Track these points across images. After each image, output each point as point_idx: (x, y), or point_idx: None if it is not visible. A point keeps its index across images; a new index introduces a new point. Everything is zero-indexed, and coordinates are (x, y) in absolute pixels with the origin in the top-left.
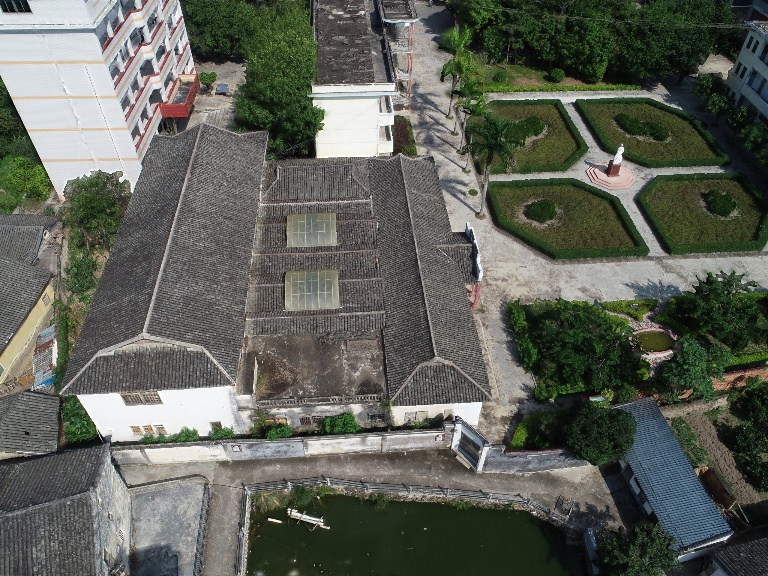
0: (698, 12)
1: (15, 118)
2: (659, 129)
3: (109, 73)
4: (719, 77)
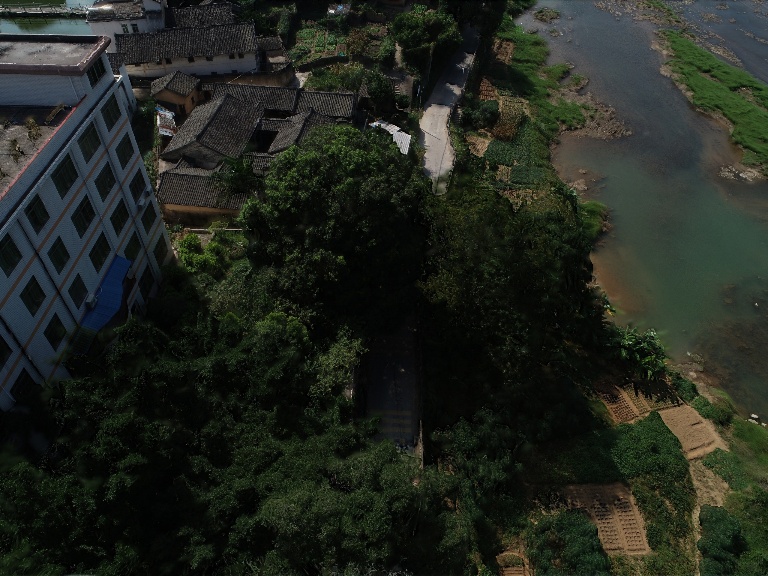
0: None
1: (214, 308)
2: None
3: None
4: None
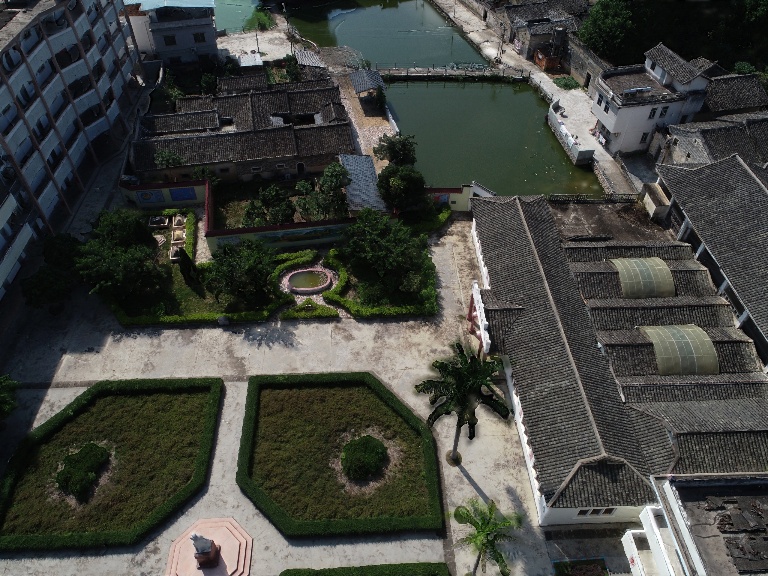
0: None
1: None
2: None
3: None
4: None
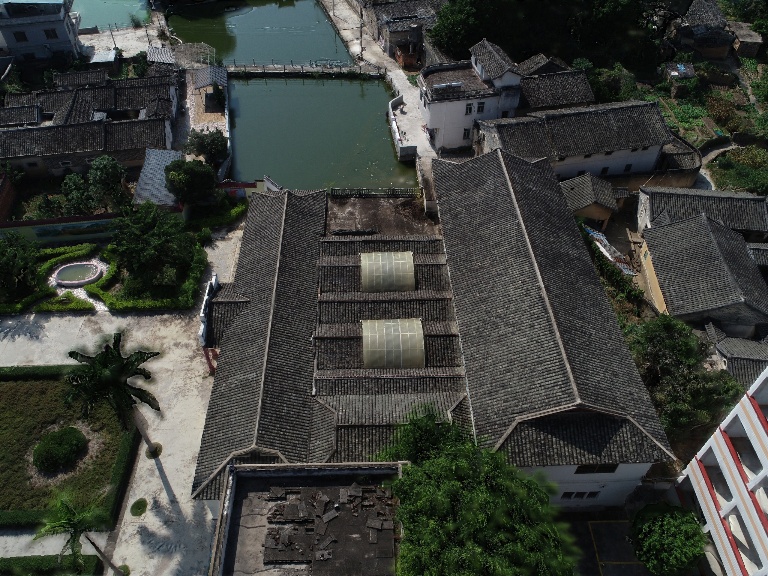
0: None
1: None
2: None
3: (762, 379)
4: None
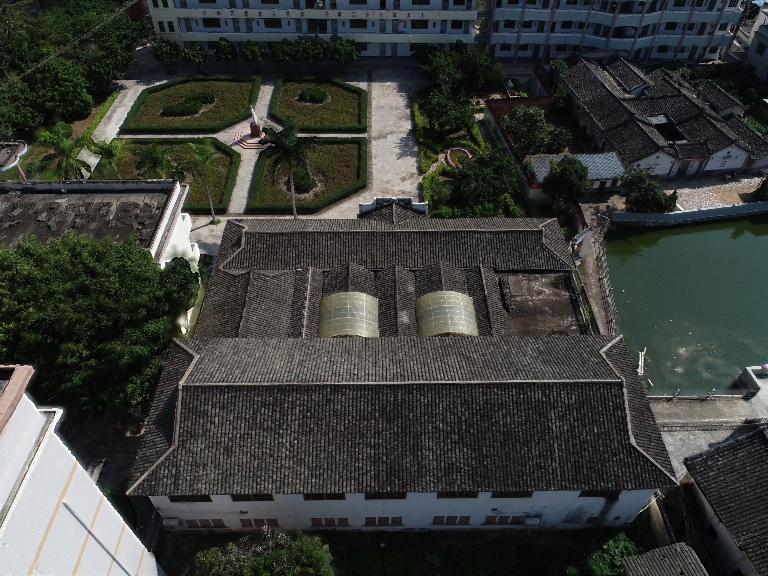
0: (94, 3)
1: None
2: (203, 95)
3: None
4: (162, 40)
